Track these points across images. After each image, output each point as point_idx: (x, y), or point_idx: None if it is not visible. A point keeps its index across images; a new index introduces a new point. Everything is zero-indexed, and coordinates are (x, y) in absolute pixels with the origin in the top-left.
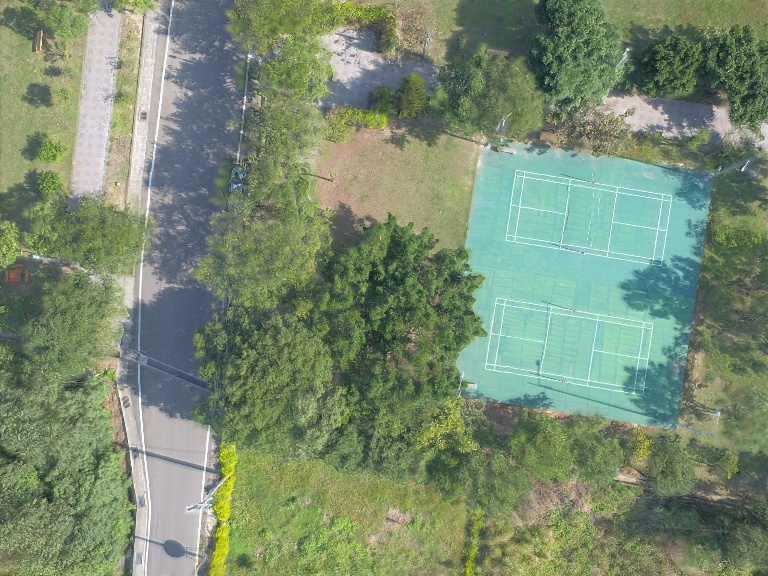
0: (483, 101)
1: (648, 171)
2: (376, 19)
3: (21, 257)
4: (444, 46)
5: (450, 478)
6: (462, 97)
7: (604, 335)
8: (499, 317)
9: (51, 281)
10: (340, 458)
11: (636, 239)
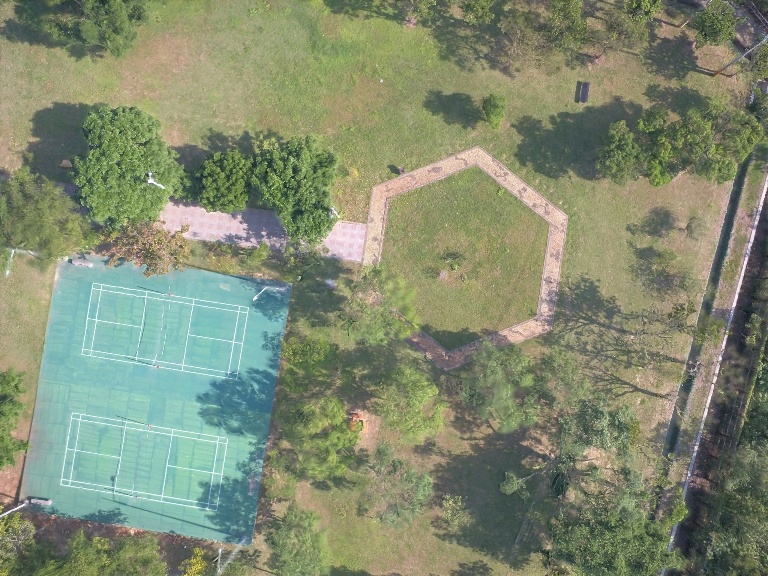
0: None
1: (225, 282)
2: None
3: None
4: (21, 158)
5: None
6: None
7: (178, 450)
8: (74, 432)
9: None
10: None
11: (211, 352)
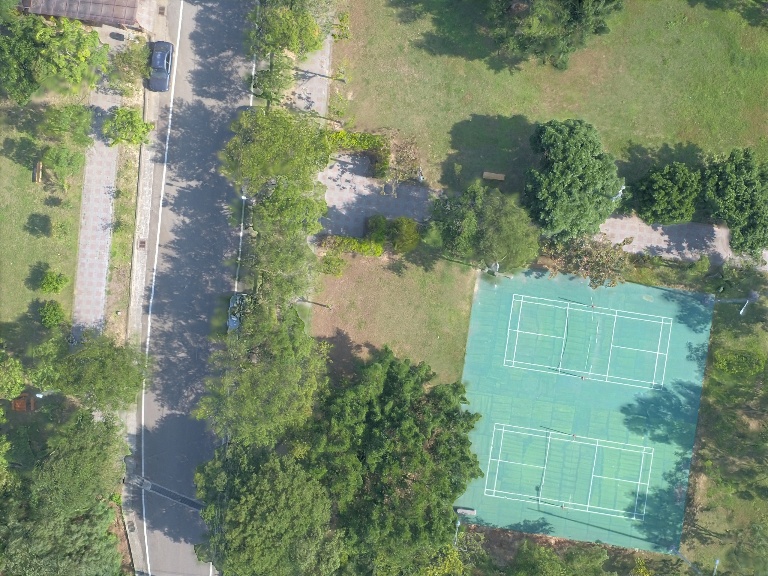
0: (477, 244)
1: (648, 293)
2: (371, 147)
3: (26, 386)
4: (440, 170)
5: None
6: (456, 240)
7: (604, 460)
8: (498, 442)
9: (56, 409)
10: None
11: (636, 363)
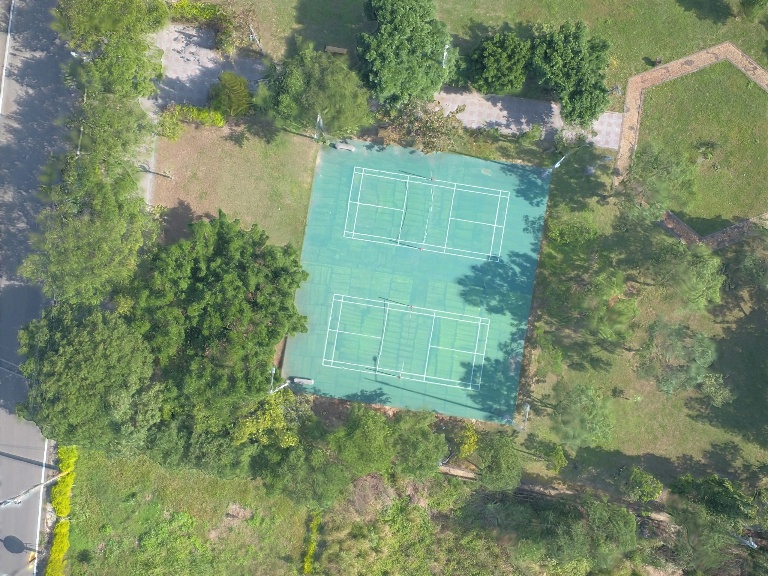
0: (300, 98)
1: (486, 167)
2: (211, 16)
3: None
4: (283, 43)
5: (271, 473)
6: (280, 94)
7: (441, 331)
8: (336, 313)
9: None
10: (163, 454)
11: (473, 235)
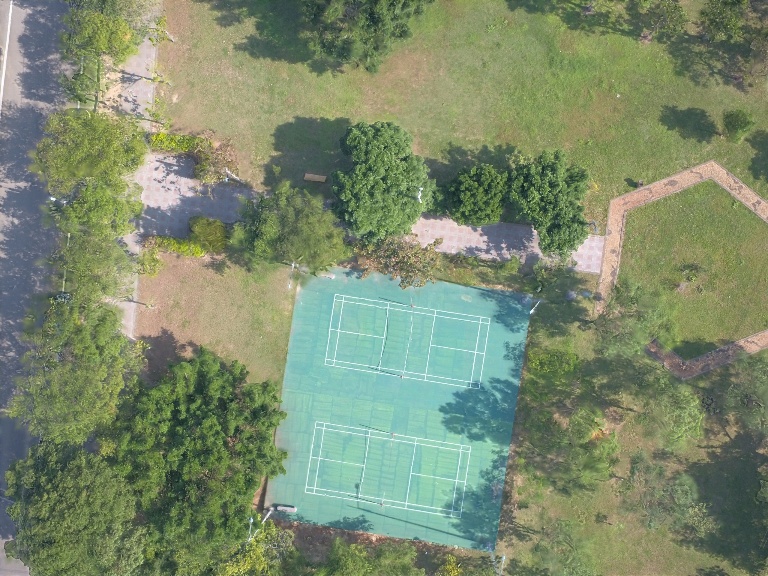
0: (275, 245)
1: (466, 293)
2: (191, 149)
3: None
4: (263, 171)
5: None
6: (255, 240)
7: (422, 458)
8: (318, 441)
9: None
10: None
11: (454, 362)
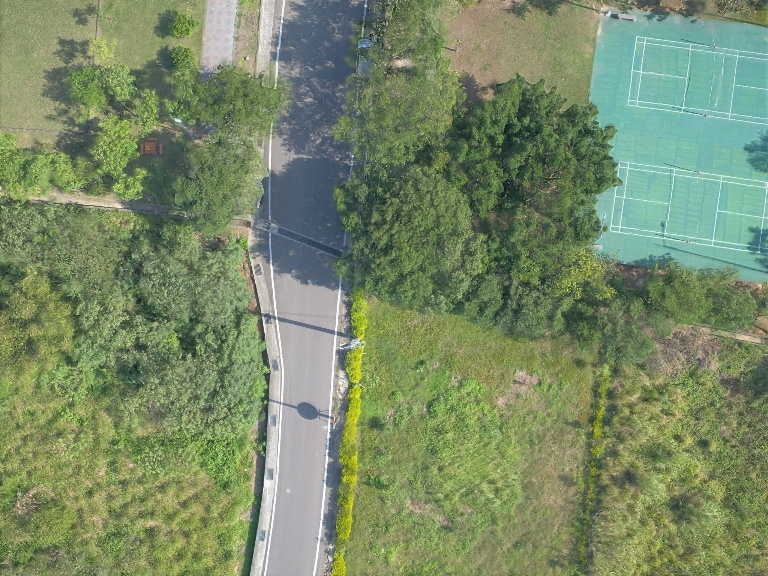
0: None
1: None
2: None
3: (155, 131)
4: None
5: (588, 325)
6: None
7: (728, 196)
8: (623, 180)
9: (184, 154)
10: (479, 307)
11: (758, 101)
